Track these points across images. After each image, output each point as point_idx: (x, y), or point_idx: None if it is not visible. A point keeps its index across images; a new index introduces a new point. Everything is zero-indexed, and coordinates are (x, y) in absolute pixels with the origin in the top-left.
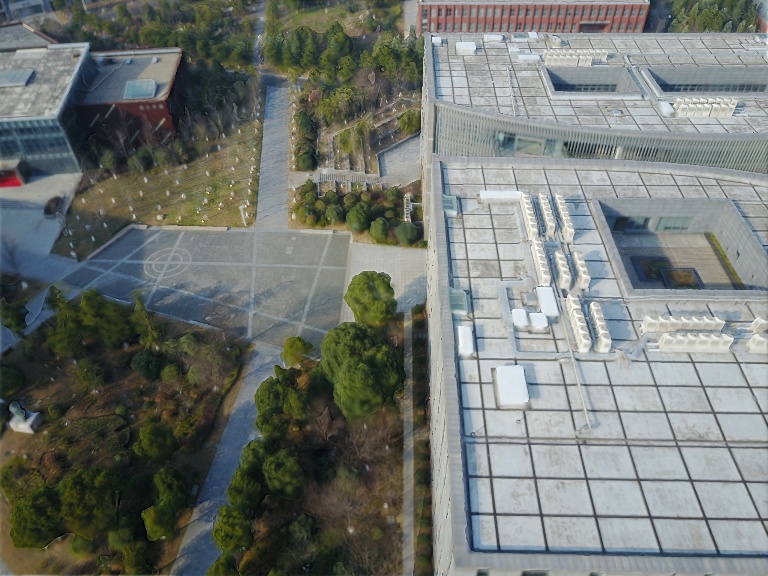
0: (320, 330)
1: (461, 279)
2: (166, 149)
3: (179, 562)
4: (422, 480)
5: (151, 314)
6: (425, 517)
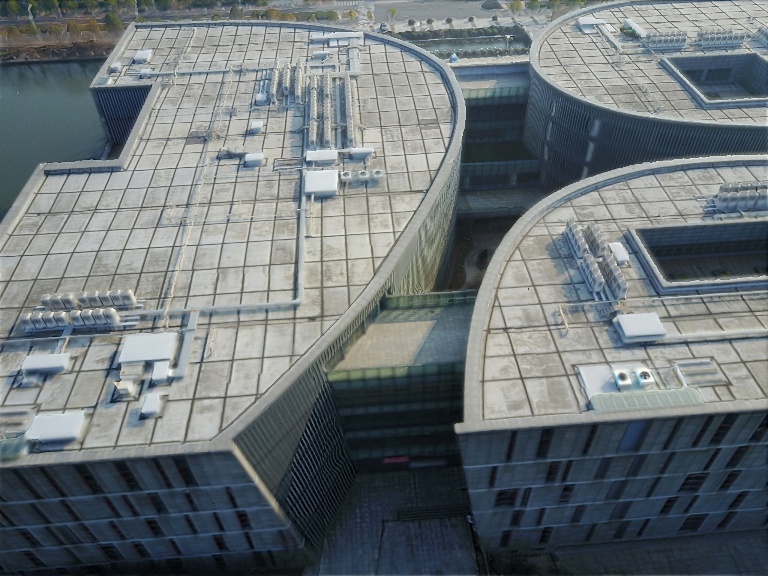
0: None
1: None
2: None
3: None
4: None
5: None
6: None
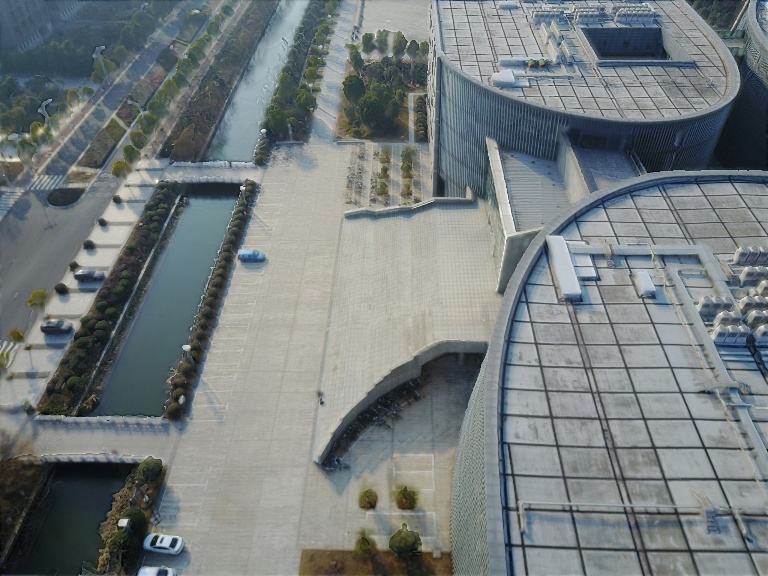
0: None
1: (571, 2)
2: (722, 14)
3: None
4: None
5: None
6: None
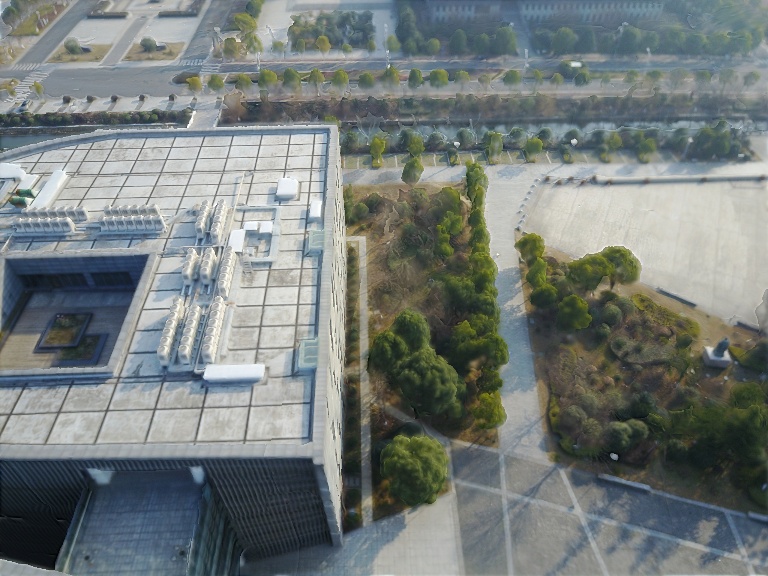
0: (478, 486)
1: (310, 267)
2: None
3: (519, 284)
4: (353, 330)
5: (674, 423)
6: (351, 312)
